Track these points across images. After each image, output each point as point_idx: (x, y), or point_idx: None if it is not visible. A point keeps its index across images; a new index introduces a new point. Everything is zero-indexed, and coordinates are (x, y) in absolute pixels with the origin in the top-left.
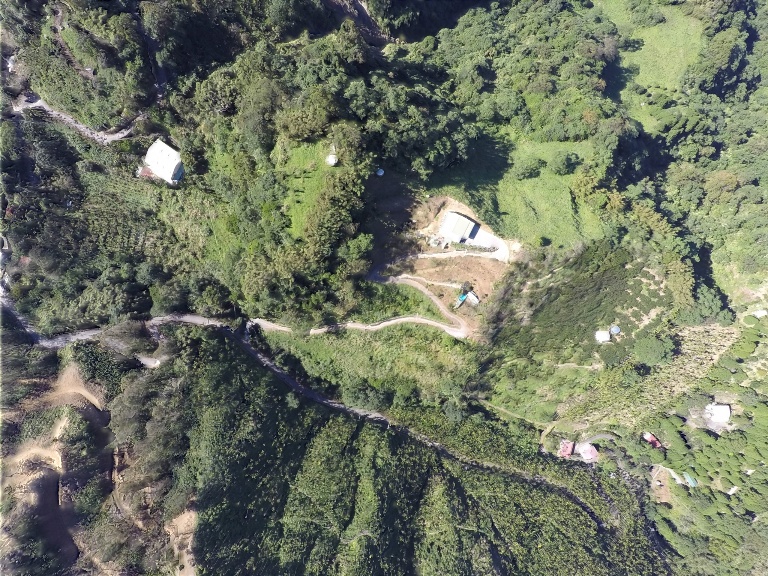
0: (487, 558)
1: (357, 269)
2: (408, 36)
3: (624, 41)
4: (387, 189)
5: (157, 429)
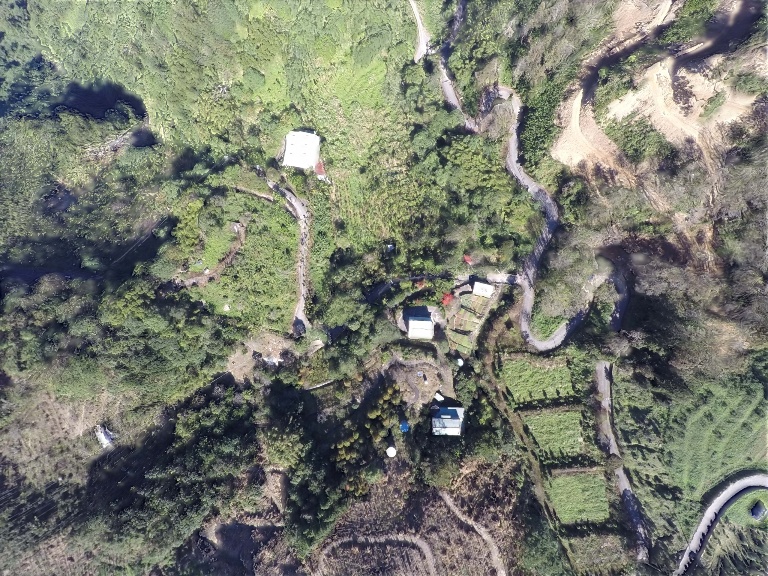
0: None
1: None
2: None
3: None
4: None
5: None
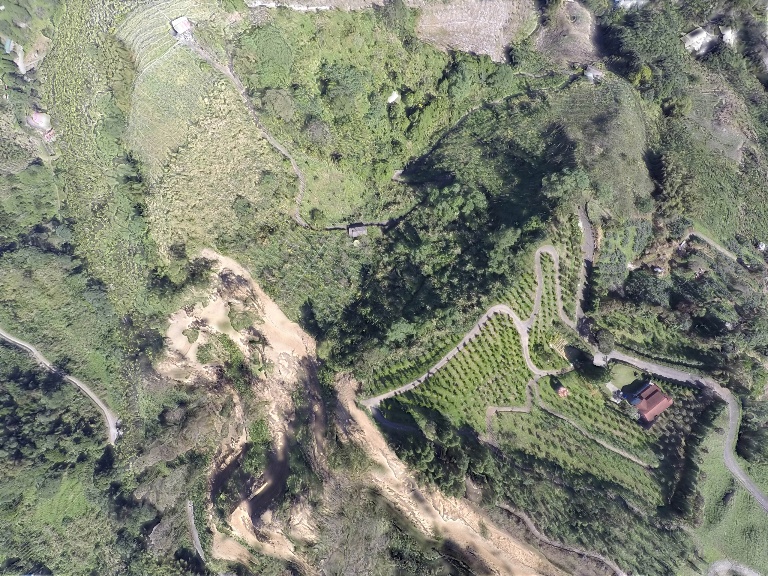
0: None
1: None
2: None
3: None
4: None
5: None
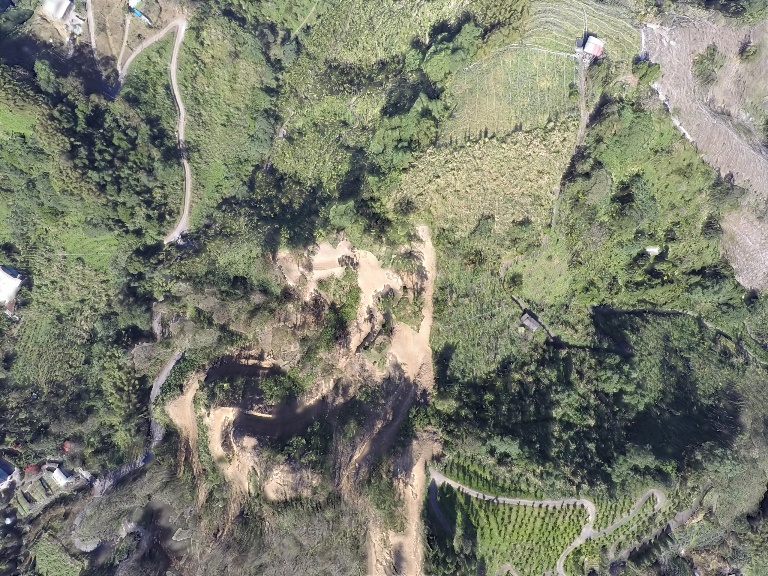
0: None
1: (78, 87)
2: None
3: None
4: (7, 51)
5: (207, 298)
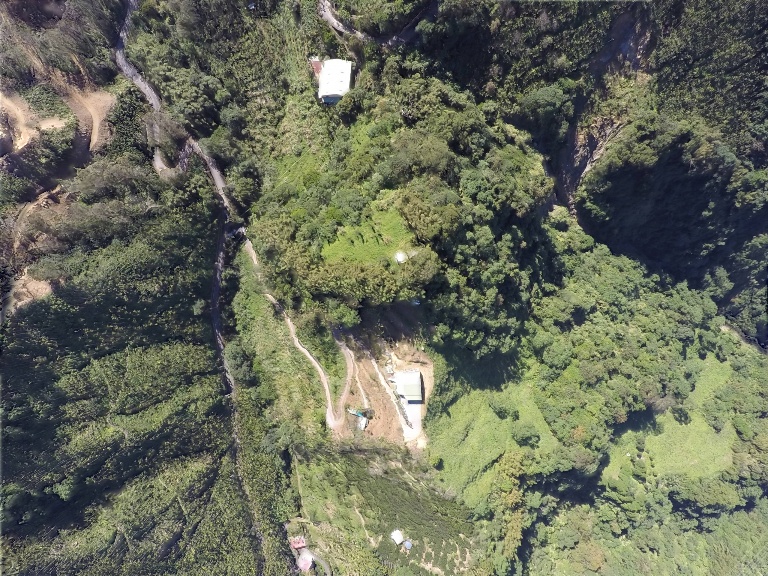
0: (167, 535)
1: None
2: (584, 218)
3: (680, 407)
4: (408, 312)
5: (100, 215)
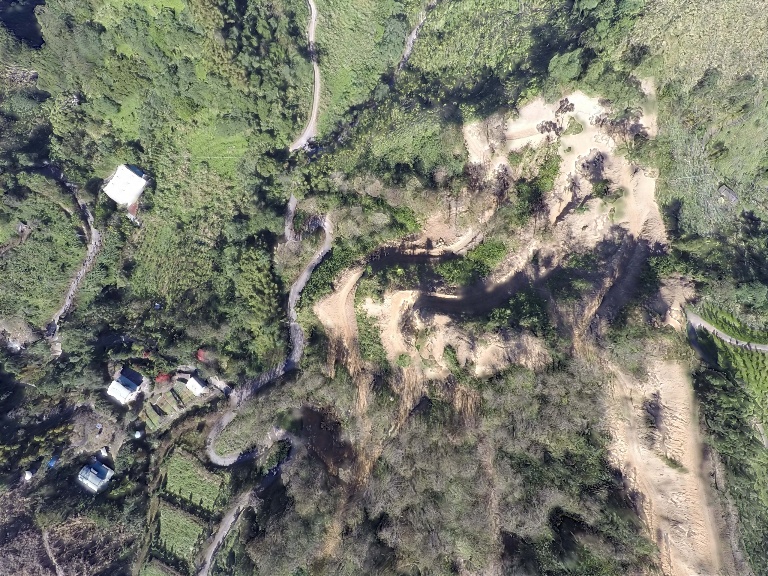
0: None
1: None
2: None
3: None
4: None
5: (376, 181)
